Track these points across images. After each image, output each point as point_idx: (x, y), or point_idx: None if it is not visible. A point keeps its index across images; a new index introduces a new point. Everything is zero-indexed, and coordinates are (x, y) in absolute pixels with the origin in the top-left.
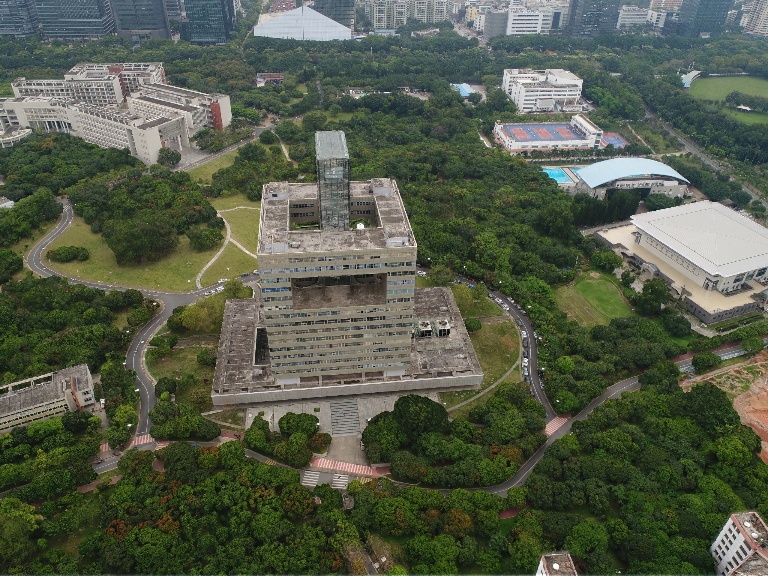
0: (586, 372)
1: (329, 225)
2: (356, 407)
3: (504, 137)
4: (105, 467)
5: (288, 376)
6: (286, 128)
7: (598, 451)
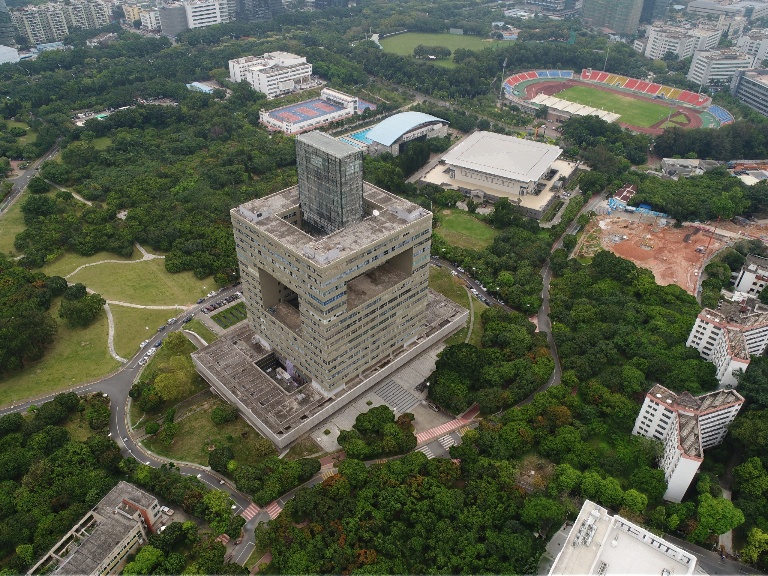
0: (523, 278)
1: (348, 221)
2: (397, 384)
3: (279, 123)
4: (239, 560)
5: (341, 383)
6: (57, 169)
7: (579, 325)
